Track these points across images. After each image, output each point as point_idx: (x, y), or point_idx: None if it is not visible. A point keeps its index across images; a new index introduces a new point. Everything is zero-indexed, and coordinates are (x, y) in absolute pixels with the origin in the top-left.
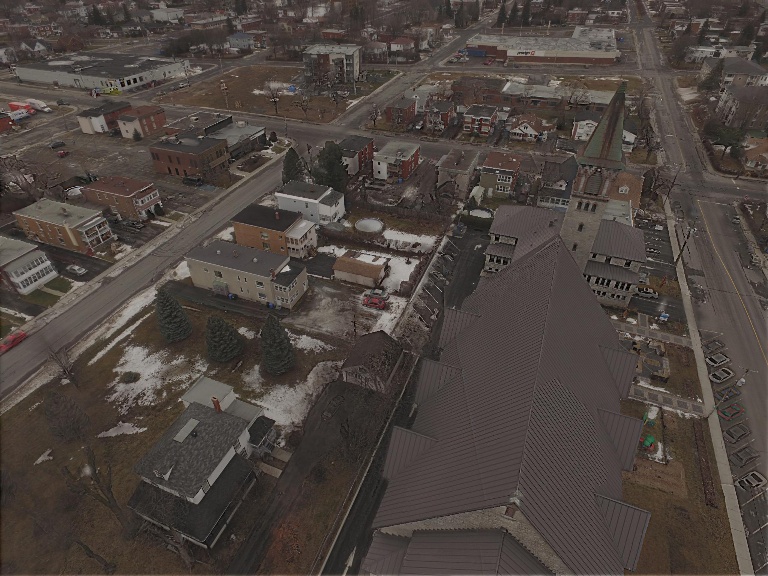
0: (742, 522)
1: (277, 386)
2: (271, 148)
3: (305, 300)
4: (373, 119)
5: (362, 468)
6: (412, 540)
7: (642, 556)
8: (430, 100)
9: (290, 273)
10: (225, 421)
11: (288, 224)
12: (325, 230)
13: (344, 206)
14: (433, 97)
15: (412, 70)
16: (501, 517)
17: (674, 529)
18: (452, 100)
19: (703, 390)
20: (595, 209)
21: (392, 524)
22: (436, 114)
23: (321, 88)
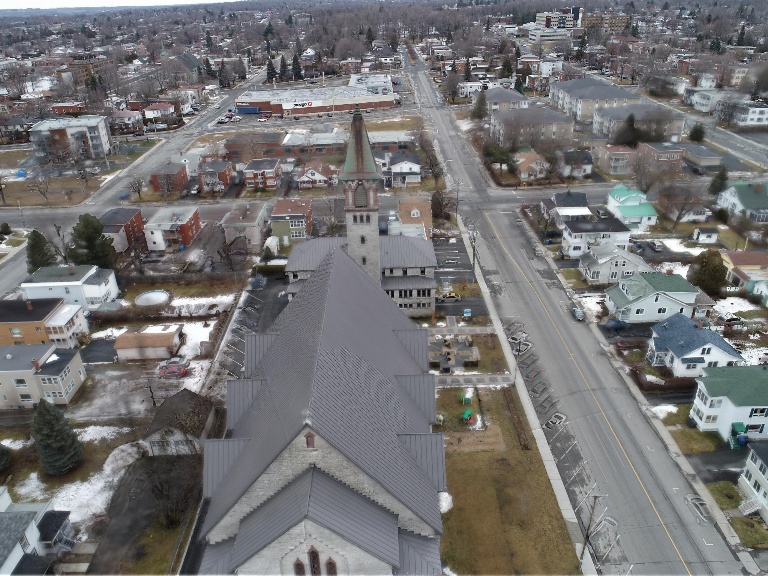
0: (551, 453)
1: (65, 486)
2: (4, 242)
3: (85, 391)
4: (137, 191)
5: (187, 528)
6: (240, 528)
7: (474, 506)
8: (203, 163)
9: (59, 361)
10: (4, 516)
11: (46, 312)
12: (97, 313)
13: (116, 284)
14: (206, 159)
15: (176, 136)
16: (305, 452)
17: (498, 477)
18: (229, 159)
19: (509, 364)
20: (369, 220)
21: (217, 520)
22: (212, 174)
23: (62, 168)
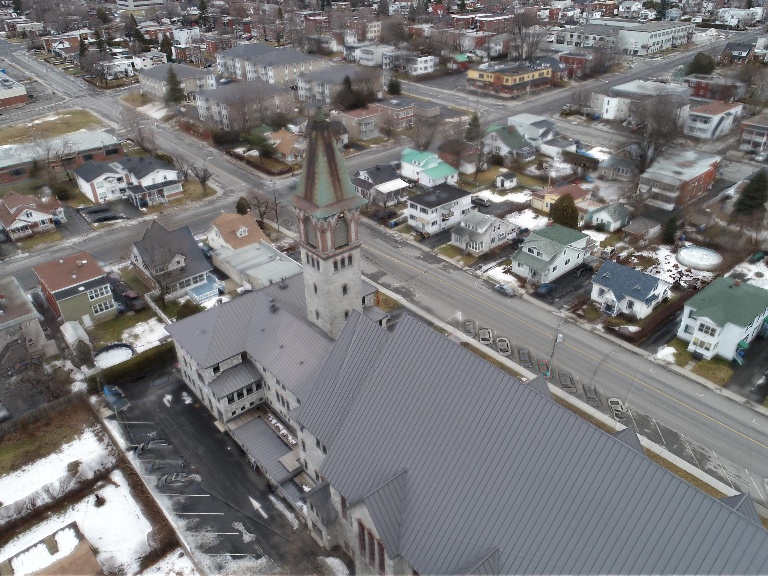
0: (654, 443)
1: None
2: None
3: None
4: None
5: None
6: None
7: None
8: None
9: None
10: None
11: None
12: None
13: None
14: None
15: None
16: None
17: None
18: None
19: (514, 369)
20: (351, 261)
21: None
22: None
23: None
